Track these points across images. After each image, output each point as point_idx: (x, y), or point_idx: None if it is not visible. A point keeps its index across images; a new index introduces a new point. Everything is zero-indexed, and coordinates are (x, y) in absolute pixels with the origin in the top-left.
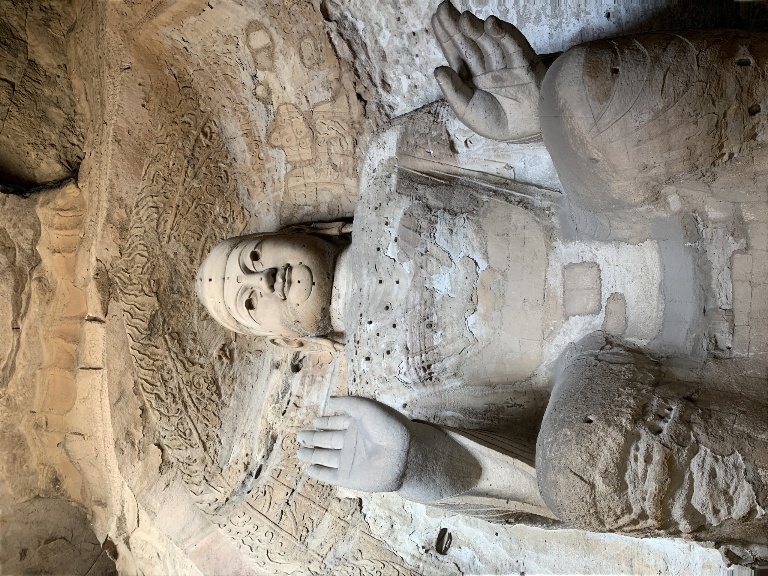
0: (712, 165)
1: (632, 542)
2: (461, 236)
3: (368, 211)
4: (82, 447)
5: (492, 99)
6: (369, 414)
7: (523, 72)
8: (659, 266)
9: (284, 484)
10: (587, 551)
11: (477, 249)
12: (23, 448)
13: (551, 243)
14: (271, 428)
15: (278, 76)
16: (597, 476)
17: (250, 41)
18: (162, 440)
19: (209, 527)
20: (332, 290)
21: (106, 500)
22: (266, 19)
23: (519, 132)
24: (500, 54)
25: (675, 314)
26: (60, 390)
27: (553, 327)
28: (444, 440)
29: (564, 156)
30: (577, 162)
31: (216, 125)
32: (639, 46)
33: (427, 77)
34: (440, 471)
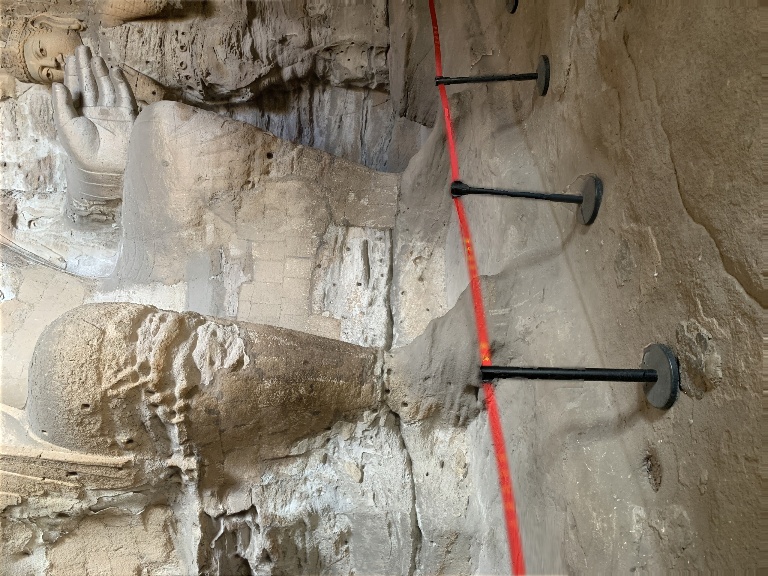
0: (241, 189)
1: None
2: None
3: None
4: None
5: (93, 126)
6: None
7: (127, 111)
8: (184, 305)
9: None
10: None
11: (8, 284)
12: None
13: (90, 293)
14: None
15: None
16: (110, 325)
17: None
18: None
19: None
20: None
21: None
22: None
23: (105, 161)
24: (113, 98)
25: None
26: None
27: None
28: None
29: (143, 159)
30: (151, 165)
31: None
32: None
33: None
34: None
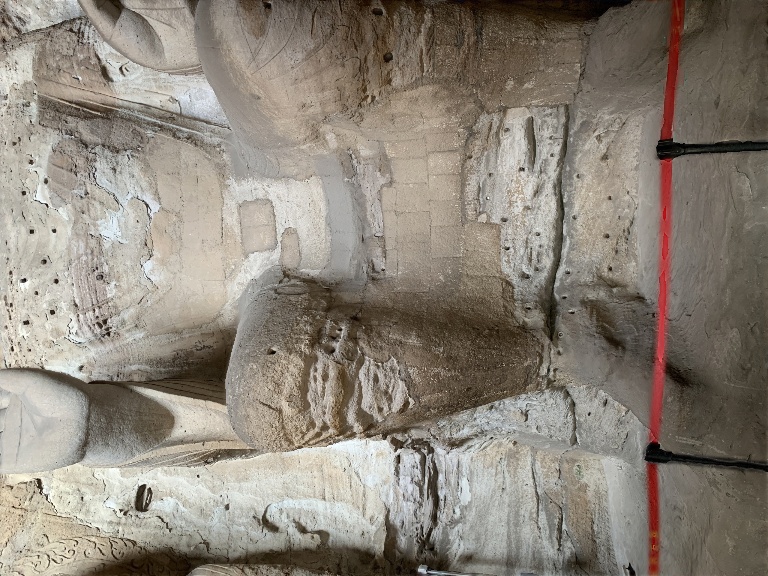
0: (359, 106)
1: (321, 450)
2: (126, 176)
3: (4, 147)
4: None
5: (143, 22)
6: (34, 386)
7: None
8: (324, 200)
9: None
10: (284, 469)
11: (146, 190)
12: None
13: (224, 181)
14: None
15: None
16: (283, 402)
17: None
18: None
19: None
20: None
21: None
22: None
23: (178, 62)
24: None
25: (340, 244)
26: None
27: (234, 266)
28: (129, 397)
29: (226, 91)
30: (240, 98)
31: None
32: None
33: None
34: (128, 430)
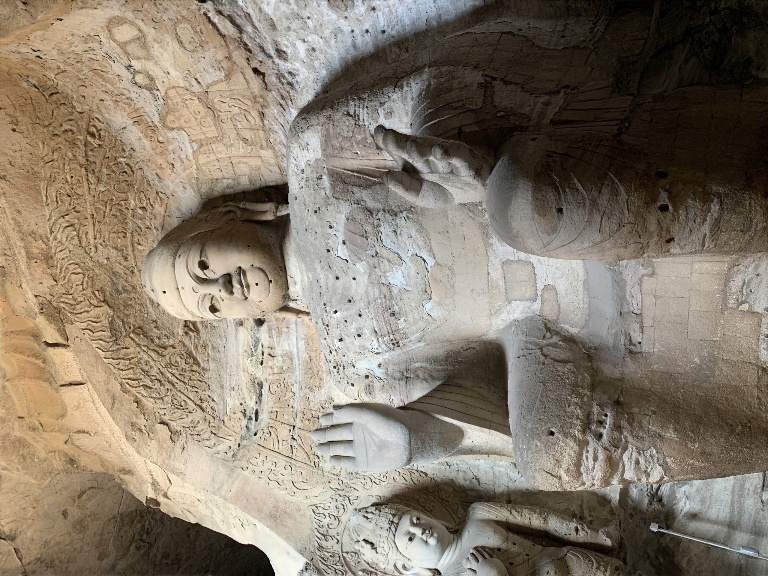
0: None
1: None
2: (406, 237)
3: (307, 213)
4: (91, 441)
5: (439, 188)
6: (372, 421)
7: (470, 179)
8: (583, 269)
9: (284, 423)
10: None
11: (423, 248)
12: (27, 447)
13: (488, 240)
14: (255, 378)
15: (157, 63)
16: (562, 472)
17: (114, 35)
18: (164, 417)
19: (234, 472)
20: (287, 279)
21: (132, 471)
22: (129, 13)
23: None
24: (446, 162)
25: (598, 309)
26: (40, 396)
27: (498, 307)
28: (433, 423)
29: None
30: None
31: (100, 121)
32: (578, 185)
33: (324, 39)
34: (435, 446)
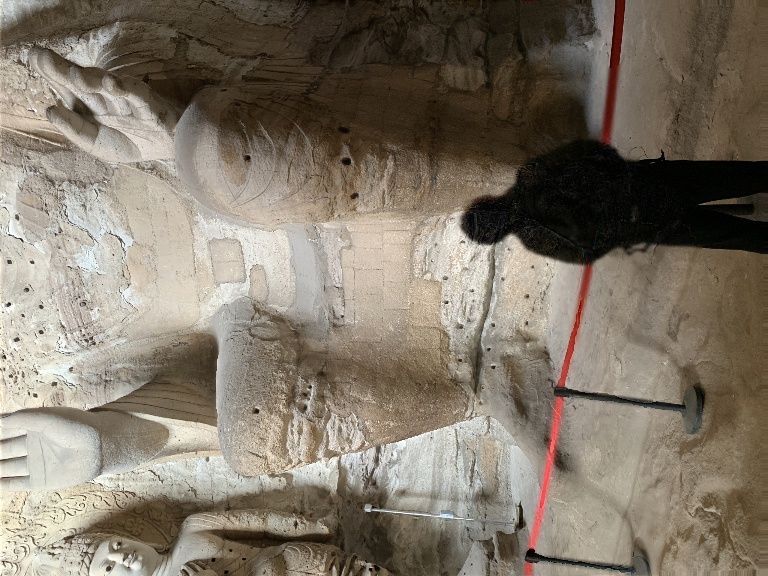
0: None
1: None
2: (97, 212)
3: None
4: None
5: (120, 136)
6: (50, 427)
7: (153, 124)
8: (289, 246)
9: None
10: None
11: (118, 225)
12: None
13: (193, 218)
14: None
15: None
16: (268, 451)
17: None
18: None
19: None
20: None
21: None
22: None
23: None
24: (123, 102)
25: (304, 286)
26: None
27: (207, 292)
28: (131, 422)
29: None
30: None
31: None
32: (265, 133)
33: None
34: (134, 449)
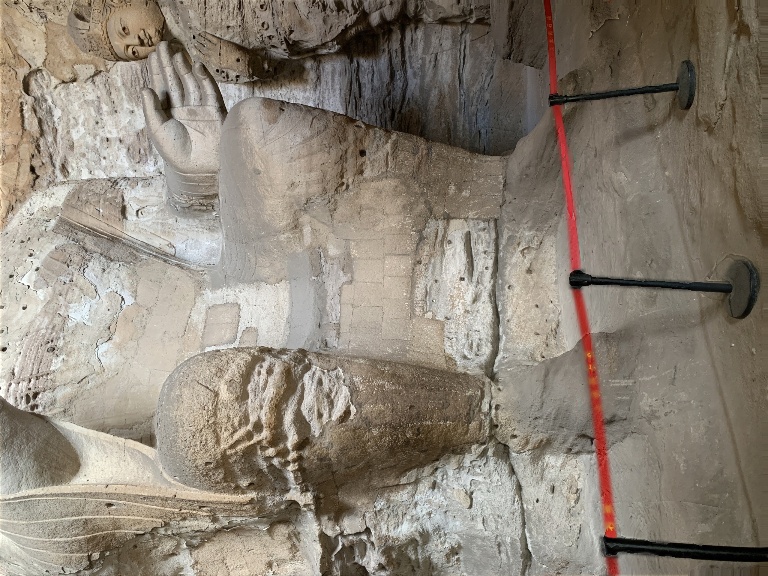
0: (336, 191)
1: None
2: (113, 276)
3: (11, 244)
4: None
5: (183, 128)
6: None
7: (214, 110)
8: (288, 304)
9: None
10: None
11: (127, 288)
12: None
13: (200, 291)
14: None
15: None
16: (222, 385)
17: None
18: None
19: None
20: None
21: None
22: None
23: (198, 164)
24: (199, 95)
25: (297, 335)
26: None
27: None
28: (43, 424)
29: (235, 167)
30: (244, 173)
31: None
32: None
33: None
34: (28, 453)
